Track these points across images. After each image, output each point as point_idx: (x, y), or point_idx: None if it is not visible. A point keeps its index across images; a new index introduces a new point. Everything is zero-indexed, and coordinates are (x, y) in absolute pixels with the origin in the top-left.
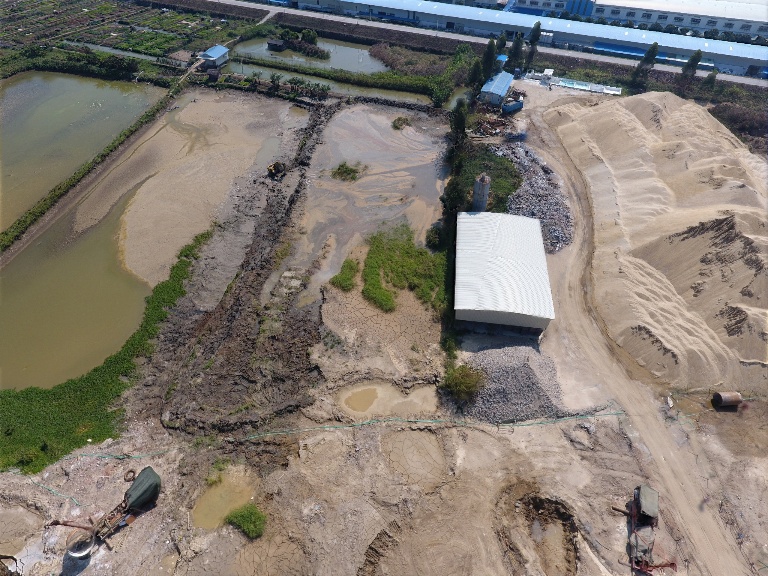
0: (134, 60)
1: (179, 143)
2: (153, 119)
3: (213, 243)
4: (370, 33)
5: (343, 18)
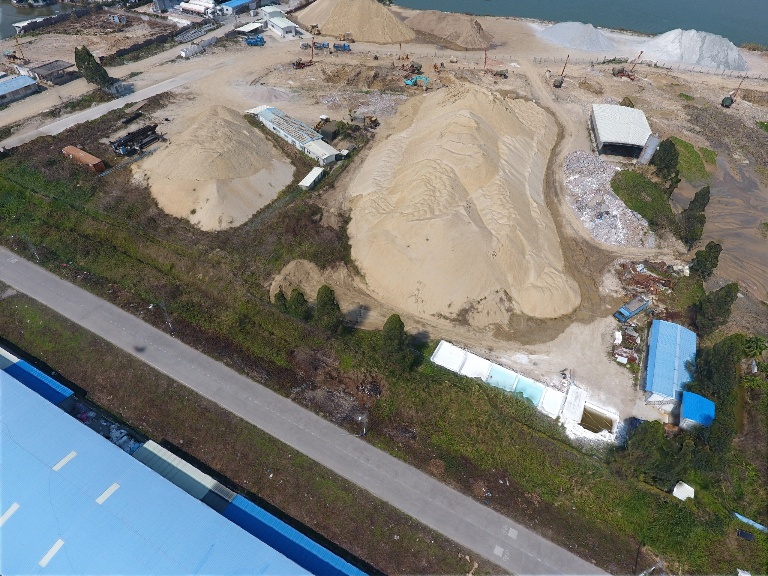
0: None
1: None
2: None
3: None
4: None
5: None
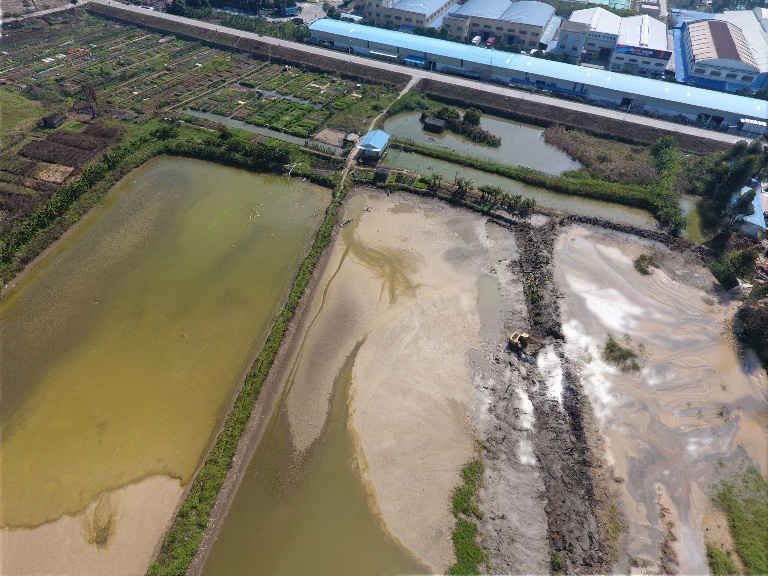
0: (288, 151)
1: (374, 283)
2: (330, 240)
3: (490, 484)
4: (539, 111)
5: (501, 89)
